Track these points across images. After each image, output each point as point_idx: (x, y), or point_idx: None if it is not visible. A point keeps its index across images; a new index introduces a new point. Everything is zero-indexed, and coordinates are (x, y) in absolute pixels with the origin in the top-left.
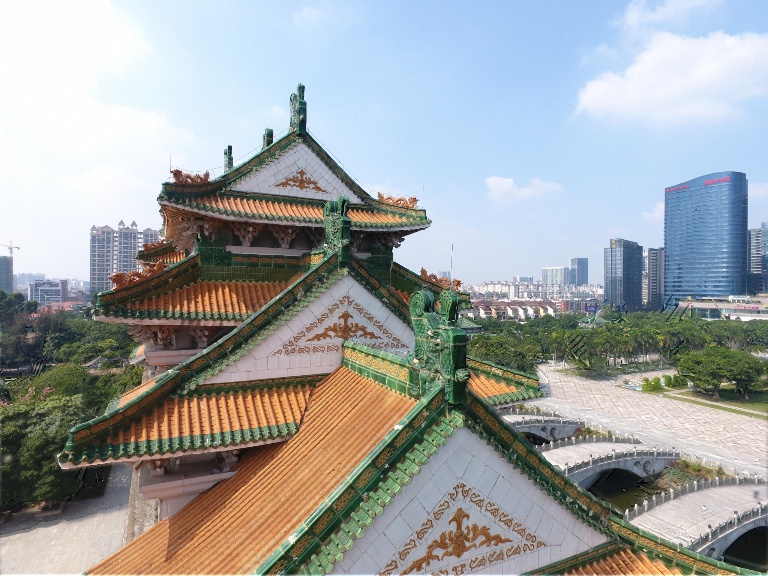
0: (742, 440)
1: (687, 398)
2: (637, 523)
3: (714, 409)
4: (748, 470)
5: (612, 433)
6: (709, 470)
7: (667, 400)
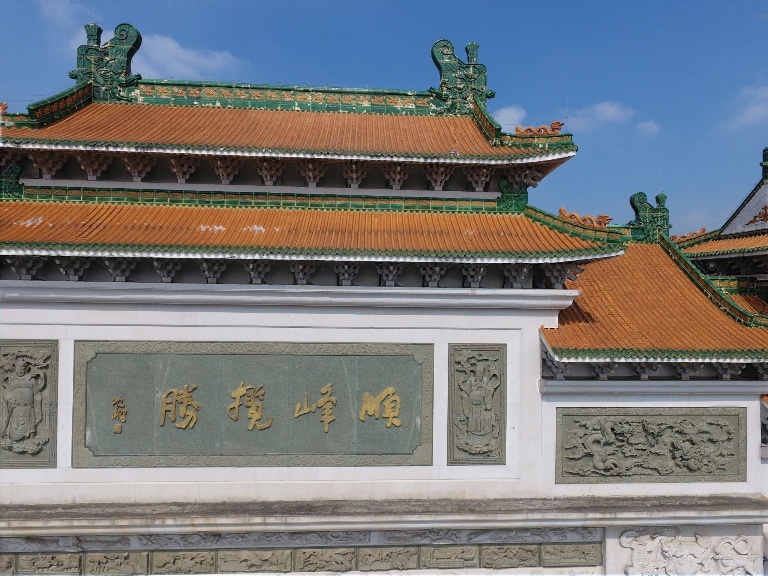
0: None
1: None
2: None
3: None
4: None
5: None
6: None
7: None
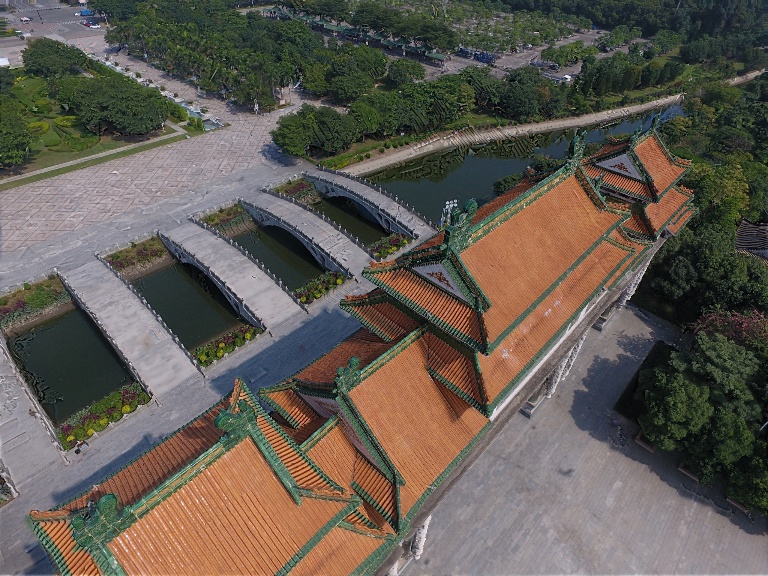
0: (150, 187)
1: (5, 183)
2: (326, 250)
3: (51, 178)
4: (214, 200)
5: (133, 242)
6: (217, 214)
7: (5, 195)
